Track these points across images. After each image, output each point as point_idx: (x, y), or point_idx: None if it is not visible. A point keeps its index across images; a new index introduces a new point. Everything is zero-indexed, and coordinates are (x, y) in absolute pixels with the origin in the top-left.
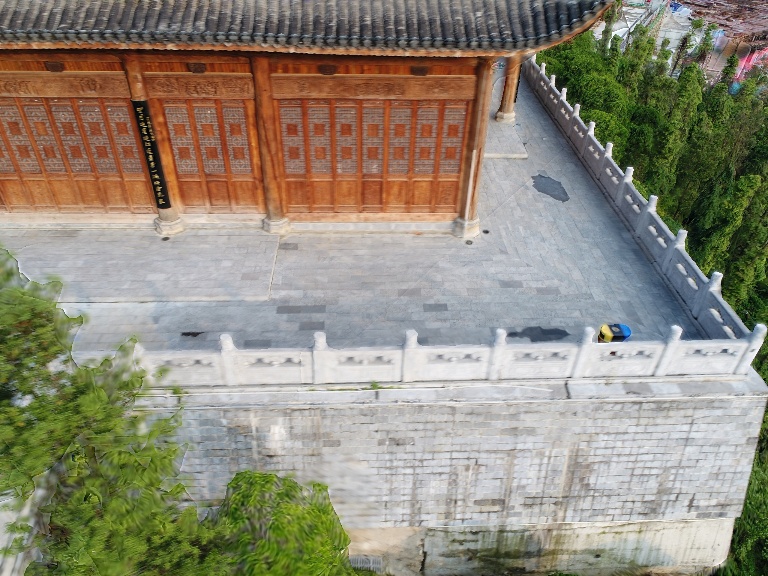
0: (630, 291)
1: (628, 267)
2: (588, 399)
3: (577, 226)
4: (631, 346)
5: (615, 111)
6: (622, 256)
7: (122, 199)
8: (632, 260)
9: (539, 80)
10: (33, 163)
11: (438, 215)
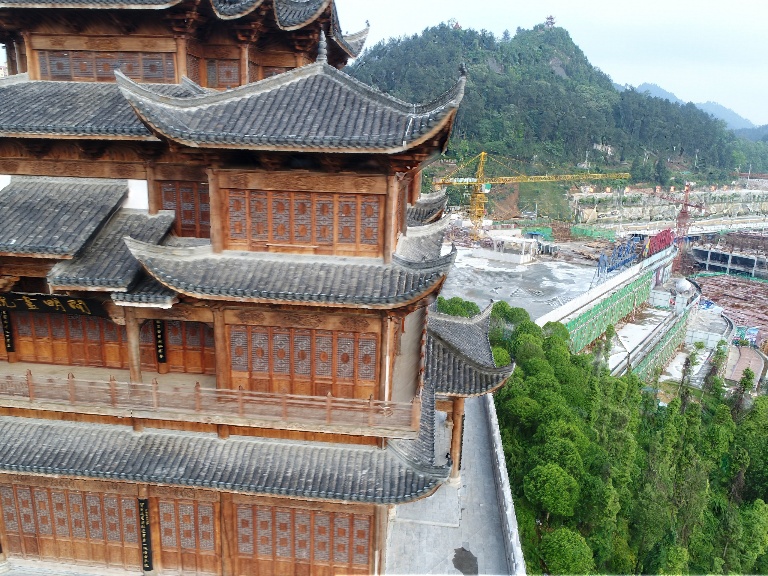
0: None
1: None
2: None
3: None
4: None
5: (569, 464)
6: None
7: (120, 559)
8: None
9: (493, 441)
10: (66, 530)
11: None
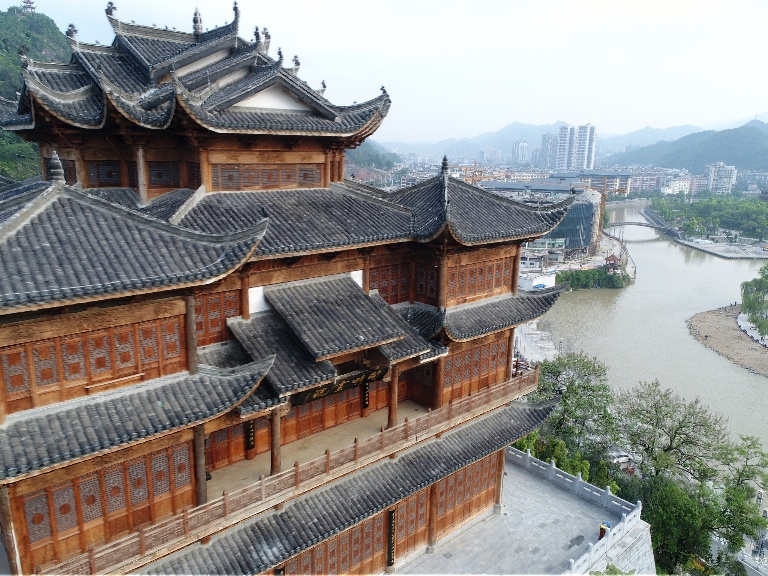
0: (577, 507)
1: (564, 496)
2: (616, 557)
3: (526, 486)
4: (617, 528)
5: None
6: (556, 492)
7: (370, 571)
8: (561, 493)
9: None
10: (335, 571)
11: (488, 507)
